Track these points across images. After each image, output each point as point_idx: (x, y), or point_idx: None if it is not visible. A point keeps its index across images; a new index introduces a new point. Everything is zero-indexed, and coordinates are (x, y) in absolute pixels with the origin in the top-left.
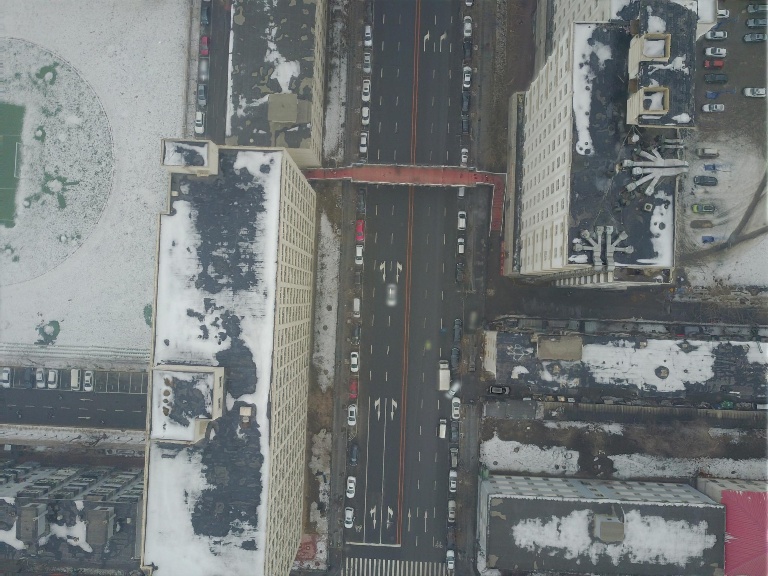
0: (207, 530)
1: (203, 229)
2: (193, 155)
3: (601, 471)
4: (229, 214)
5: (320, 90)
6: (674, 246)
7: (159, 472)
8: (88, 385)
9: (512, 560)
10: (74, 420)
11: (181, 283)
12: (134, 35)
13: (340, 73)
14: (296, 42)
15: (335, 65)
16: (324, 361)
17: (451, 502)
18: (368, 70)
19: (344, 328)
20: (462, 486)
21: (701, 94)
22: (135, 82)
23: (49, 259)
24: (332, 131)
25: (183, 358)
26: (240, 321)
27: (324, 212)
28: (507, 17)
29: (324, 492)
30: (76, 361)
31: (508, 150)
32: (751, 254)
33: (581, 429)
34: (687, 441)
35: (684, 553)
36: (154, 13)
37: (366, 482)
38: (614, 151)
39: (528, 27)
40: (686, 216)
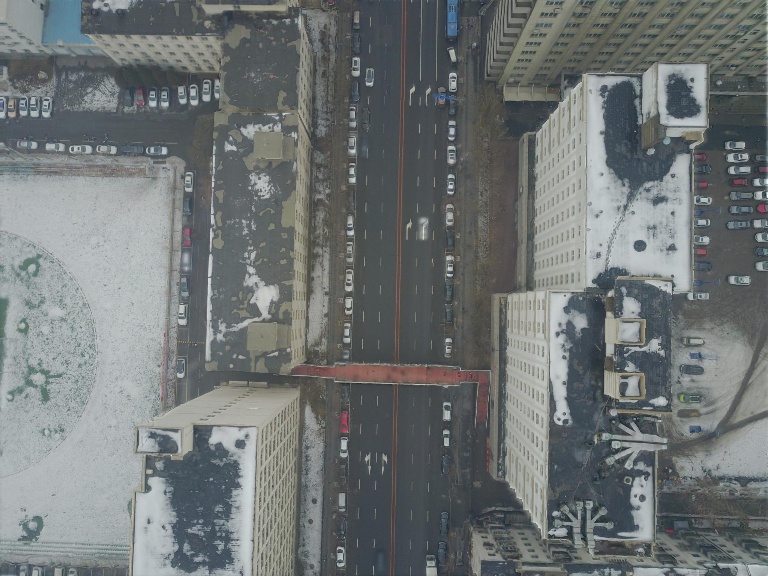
0: None
1: (178, 506)
2: (167, 441)
3: None
4: (204, 490)
5: (302, 288)
6: (655, 520)
7: None
8: None
9: None
10: None
11: (156, 562)
12: (117, 226)
13: (323, 262)
14: (275, 266)
15: (318, 254)
16: (310, 555)
17: None
18: (351, 260)
19: (330, 522)
20: None
21: None
22: (118, 274)
23: (32, 453)
24: (315, 321)
25: None
26: None
27: (308, 403)
28: (489, 205)
29: None
30: (60, 558)
31: (491, 351)
32: (739, 443)
33: None
34: None
35: None
36: (136, 204)
37: None
38: (592, 421)
39: (510, 215)
40: (673, 405)
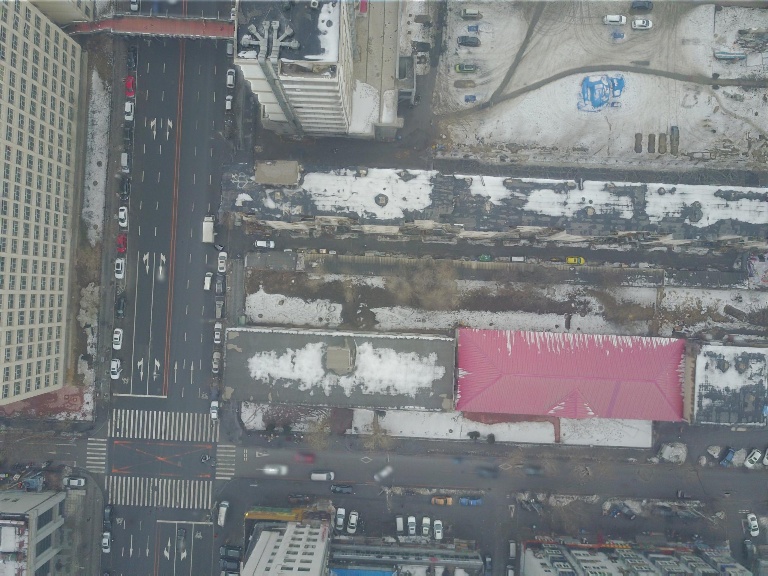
0: None
1: None
2: None
3: (363, 323)
4: None
5: None
6: (339, 42)
7: None
8: None
9: (248, 392)
10: None
11: None
12: None
13: None
14: None
15: None
16: (94, 216)
17: (215, 353)
18: None
19: (114, 184)
20: None
21: None
22: None
23: None
24: None
25: None
26: None
27: (95, 69)
28: None
29: (92, 345)
30: None
31: None
32: (512, 113)
33: None
34: (426, 281)
35: (414, 384)
36: None
37: (134, 335)
38: None
39: None
40: (450, 76)
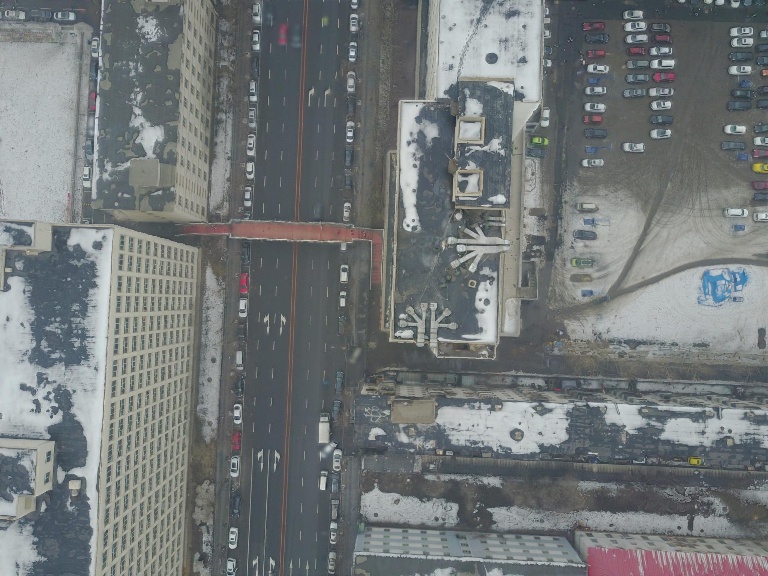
0: None
1: (37, 304)
2: (21, 234)
3: (480, 523)
4: (62, 290)
5: (201, 147)
6: (498, 322)
7: None
8: None
9: None
10: None
11: (15, 358)
12: (24, 90)
13: (226, 128)
14: (160, 107)
15: (221, 120)
16: (208, 413)
17: (331, 554)
18: (253, 125)
19: (228, 380)
20: (343, 537)
21: (581, 149)
22: (25, 137)
23: None
24: (218, 185)
25: (16, 431)
26: (72, 395)
27: (209, 265)
28: (390, 72)
29: (207, 543)
30: None
31: (382, 207)
32: (630, 308)
33: (460, 481)
34: (554, 498)
35: None
36: (44, 69)
37: (249, 533)
38: (440, 228)
39: (411, 82)
40: (566, 270)
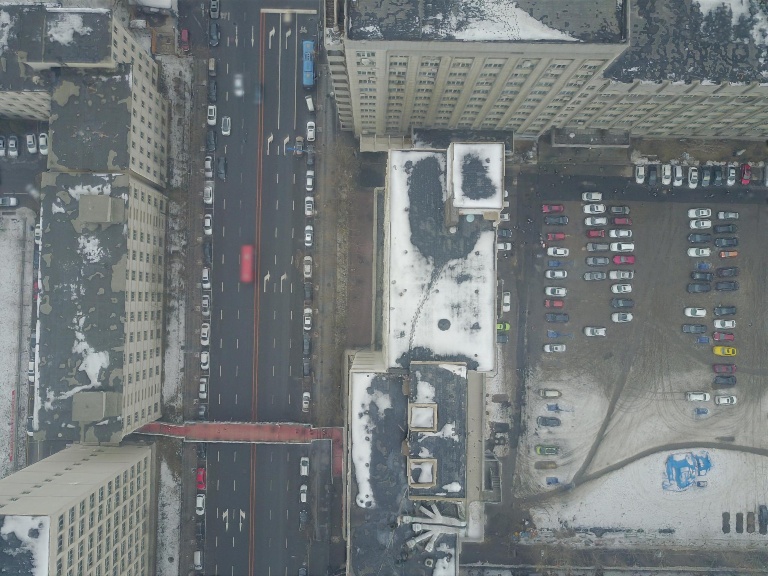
0: None
1: None
2: None
3: None
4: None
5: (152, 345)
6: None
7: None
8: None
9: None
10: None
11: None
12: None
13: (179, 316)
14: (105, 332)
15: (173, 308)
16: None
17: None
18: (207, 313)
19: None
20: None
21: (543, 333)
22: None
23: None
24: (171, 376)
25: None
26: None
27: (164, 460)
28: (348, 256)
29: None
30: None
31: (341, 409)
32: (595, 494)
33: None
34: None
35: None
36: None
37: None
38: (395, 503)
39: (369, 267)
40: (530, 457)
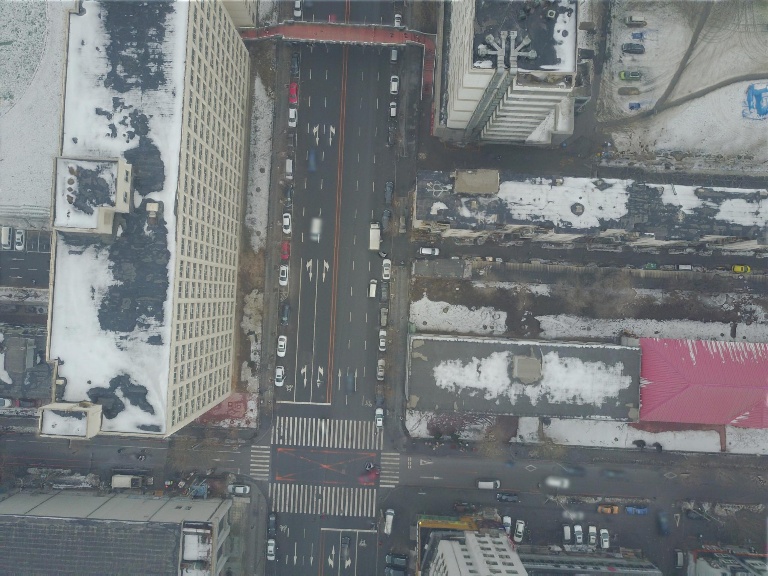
0: (113, 325)
1: (113, 29)
2: None
3: (528, 331)
4: (139, 15)
5: None
6: (576, 52)
7: (66, 268)
8: (19, 244)
9: (433, 401)
10: (5, 279)
11: (90, 82)
12: None
13: None
14: None
15: None
16: (257, 223)
17: (380, 361)
18: None
19: (277, 190)
20: (392, 346)
21: None
22: None
23: None
24: None
25: (91, 156)
26: (148, 120)
27: (258, 75)
28: None
29: (255, 352)
30: (8, 220)
31: (437, 7)
32: (676, 121)
33: (509, 290)
34: (606, 289)
35: (600, 393)
36: None
37: (297, 342)
38: None
39: None
40: (614, 83)
